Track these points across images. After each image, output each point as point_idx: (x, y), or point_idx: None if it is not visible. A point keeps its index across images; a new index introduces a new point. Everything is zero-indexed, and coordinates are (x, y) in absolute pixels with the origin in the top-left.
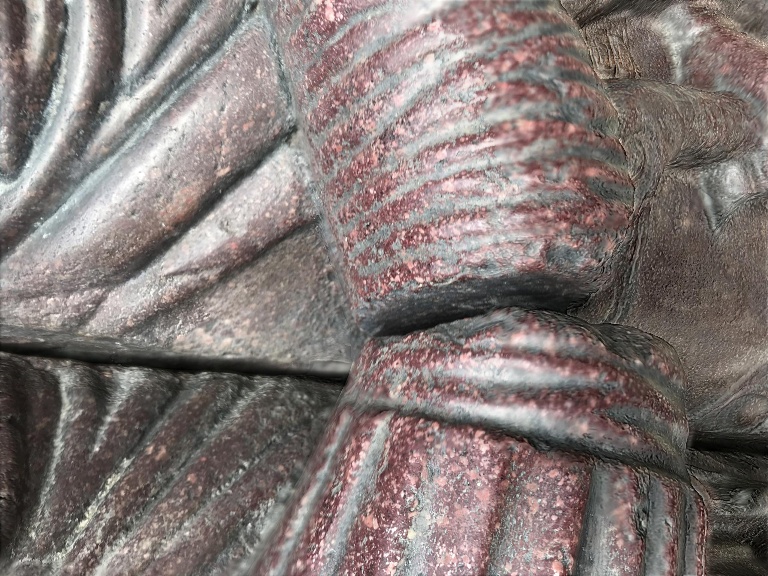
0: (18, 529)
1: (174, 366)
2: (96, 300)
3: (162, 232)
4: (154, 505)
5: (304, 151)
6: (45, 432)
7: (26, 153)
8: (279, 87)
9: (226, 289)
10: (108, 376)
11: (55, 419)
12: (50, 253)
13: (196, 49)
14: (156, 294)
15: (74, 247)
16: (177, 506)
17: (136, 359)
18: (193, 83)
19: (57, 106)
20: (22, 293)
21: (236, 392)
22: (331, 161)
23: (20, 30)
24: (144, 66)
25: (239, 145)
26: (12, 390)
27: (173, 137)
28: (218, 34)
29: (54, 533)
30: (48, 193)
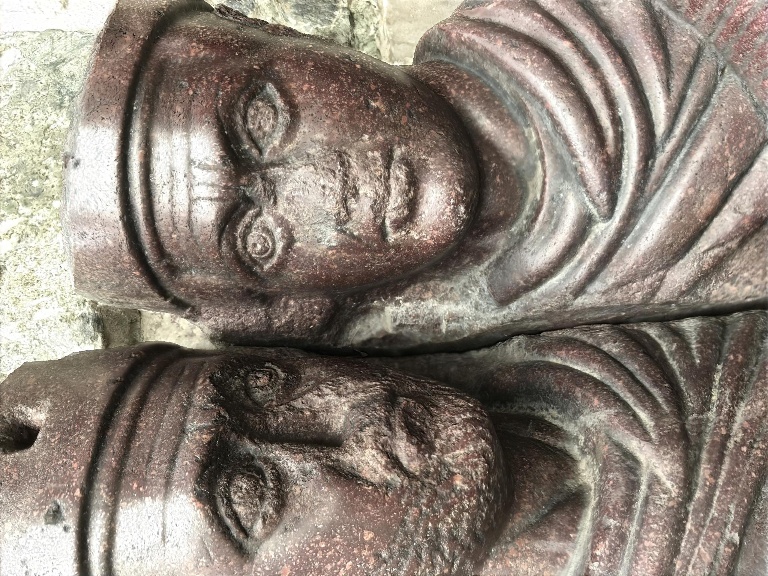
0: (681, 402)
1: (710, 314)
2: (660, 278)
3: (699, 225)
4: (751, 385)
5: None
6: (662, 357)
7: (615, 203)
8: (756, 113)
9: (742, 252)
10: (674, 326)
11: (661, 351)
12: (634, 255)
13: (696, 111)
14: (698, 265)
15: (649, 248)
16: (767, 383)
17: (681, 315)
18: (699, 131)
19: (626, 172)
20: (619, 283)
21: (766, 320)
22: None
23: (603, 139)
24: (668, 132)
25: (739, 157)
26: (632, 339)
27: (696, 166)
28: (707, 97)
29: (702, 402)
30: (629, 221)
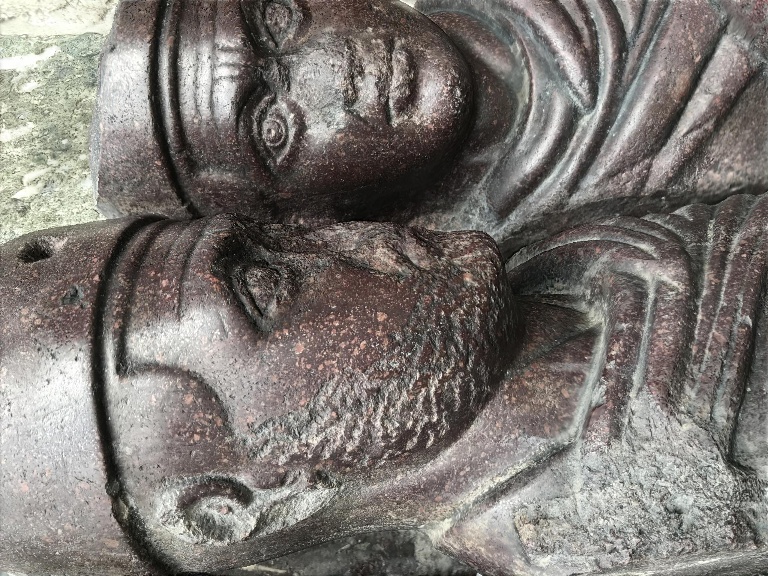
0: None
1: None
2: (647, 167)
3: (675, 106)
4: (744, 223)
5: (740, 27)
6: None
7: (597, 92)
8: (710, 4)
9: (719, 137)
10: None
11: None
12: (620, 141)
13: (658, 9)
14: (680, 149)
15: (632, 132)
16: (759, 217)
17: None
18: (663, 25)
19: (603, 64)
20: (610, 173)
21: (752, 197)
22: (765, 9)
23: (579, 36)
24: (636, 29)
25: (701, 41)
26: None
27: (665, 52)
28: None
29: None
30: (611, 109)
